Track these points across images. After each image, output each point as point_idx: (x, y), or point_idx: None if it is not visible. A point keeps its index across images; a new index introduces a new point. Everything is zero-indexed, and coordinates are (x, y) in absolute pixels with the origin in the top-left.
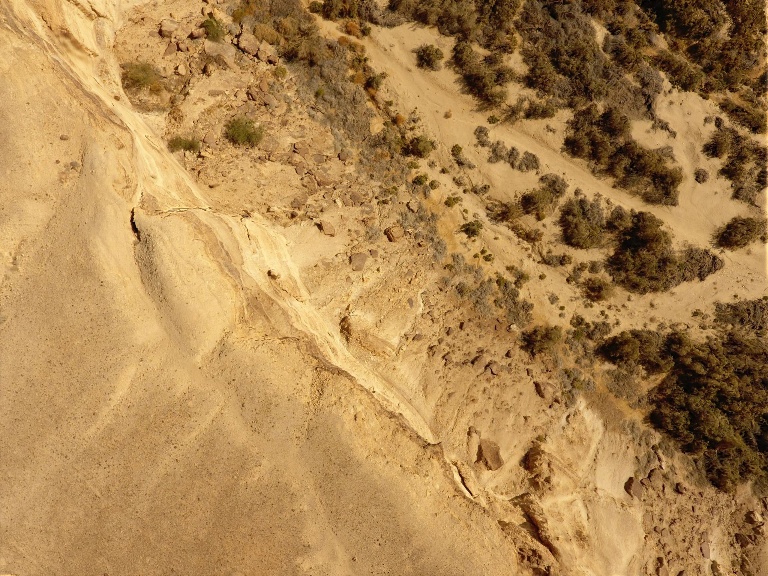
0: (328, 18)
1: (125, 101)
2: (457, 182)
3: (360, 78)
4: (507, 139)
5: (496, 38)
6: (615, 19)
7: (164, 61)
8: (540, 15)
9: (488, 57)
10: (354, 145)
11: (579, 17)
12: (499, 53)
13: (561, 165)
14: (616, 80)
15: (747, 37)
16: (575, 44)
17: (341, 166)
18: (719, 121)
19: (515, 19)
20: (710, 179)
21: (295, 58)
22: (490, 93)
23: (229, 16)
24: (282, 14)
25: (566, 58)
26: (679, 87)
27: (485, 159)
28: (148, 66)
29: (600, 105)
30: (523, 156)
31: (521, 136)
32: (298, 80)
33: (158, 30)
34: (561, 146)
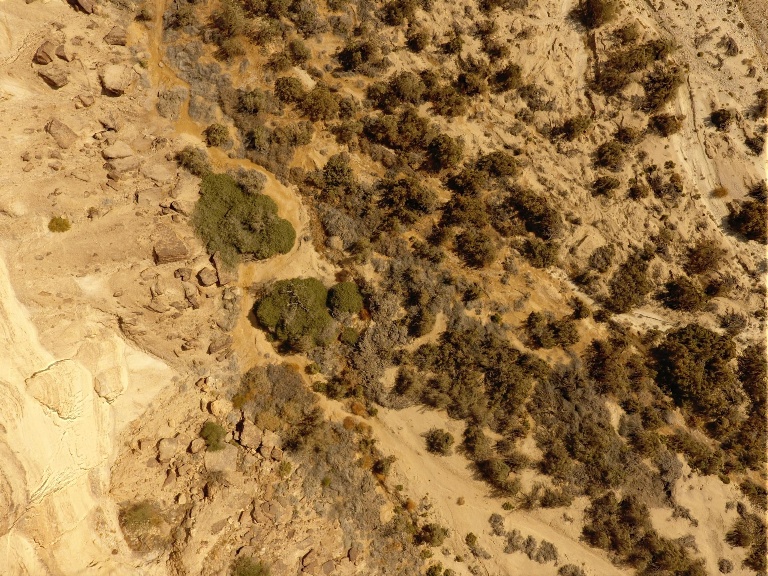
0: (332, 397)
1: (123, 551)
2: (473, 572)
3: (368, 463)
4: (523, 527)
5: (508, 426)
6: (630, 396)
7: (163, 492)
8: (552, 398)
9: (500, 442)
10: (364, 536)
11: (593, 400)
12: (512, 438)
13: (580, 554)
14: (634, 467)
15: (766, 420)
16: (590, 430)
17: (352, 568)
18: (741, 508)
19: (527, 402)
20: (734, 570)
21: (299, 444)
22: (504, 484)
23: (229, 402)
24: (284, 396)
25: (582, 449)
26: (698, 470)
27: (501, 549)
28: (147, 503)
29: (618, 493)
30: (540, 546)
31: (537, 523)
32: (303, 471)
33: (156, 456)
34: (579, 535)
